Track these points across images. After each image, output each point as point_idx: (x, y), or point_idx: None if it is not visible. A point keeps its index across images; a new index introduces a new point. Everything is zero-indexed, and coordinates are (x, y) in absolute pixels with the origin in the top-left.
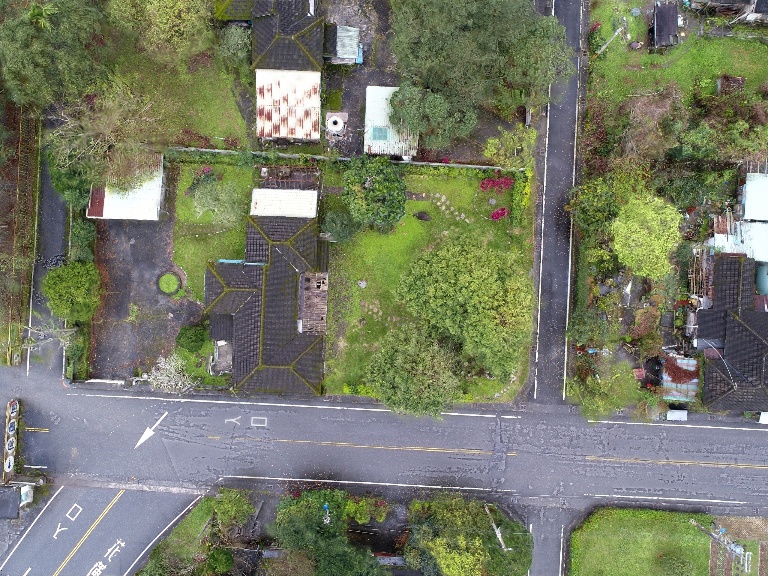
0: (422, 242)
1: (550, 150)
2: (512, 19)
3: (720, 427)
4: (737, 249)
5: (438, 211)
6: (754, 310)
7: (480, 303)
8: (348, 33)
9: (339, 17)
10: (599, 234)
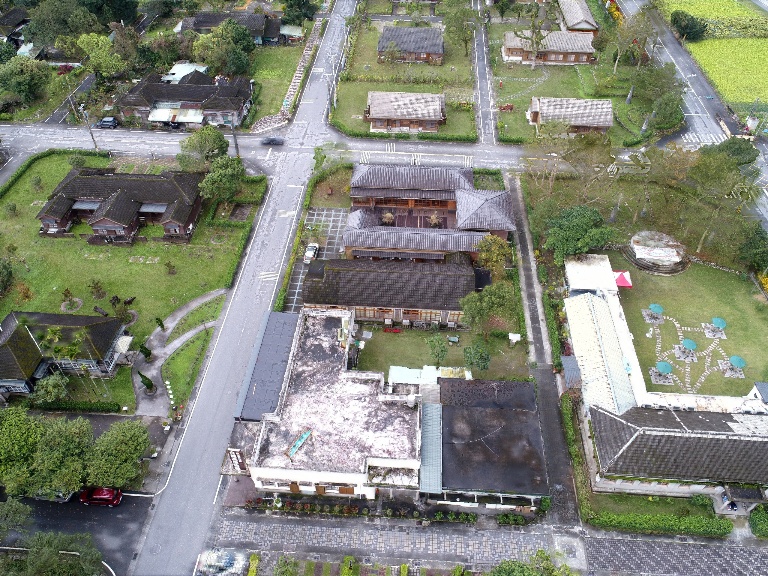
0: None
1: None
2: None
3: (135, 131)
4: None
5: None
6: None
7: None
8: None
9: None
10: None
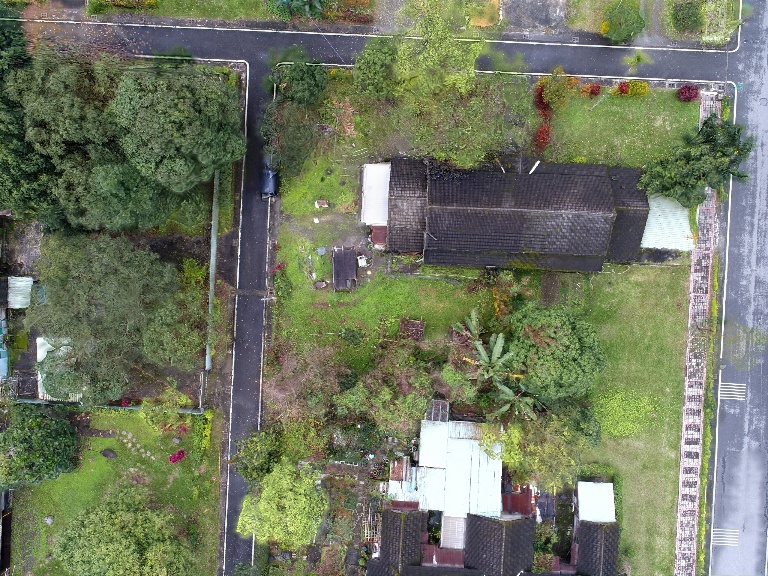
0: (109, 479)
1: (235, 388)
2: (129, 309)
3: None
4: (410, 497)
5: (124, 448)
6: (422, 561)
7: (117, 575)
8: (20, 283)
9: (26, 257)
10: (257, 491)
